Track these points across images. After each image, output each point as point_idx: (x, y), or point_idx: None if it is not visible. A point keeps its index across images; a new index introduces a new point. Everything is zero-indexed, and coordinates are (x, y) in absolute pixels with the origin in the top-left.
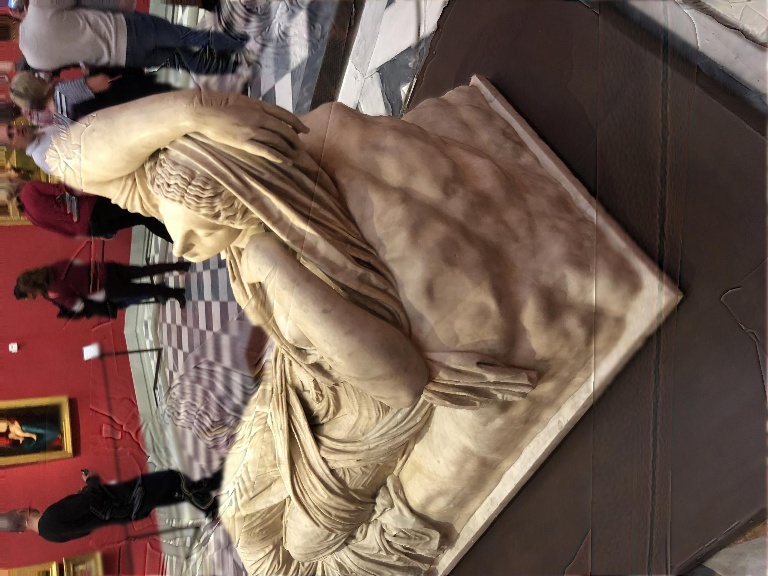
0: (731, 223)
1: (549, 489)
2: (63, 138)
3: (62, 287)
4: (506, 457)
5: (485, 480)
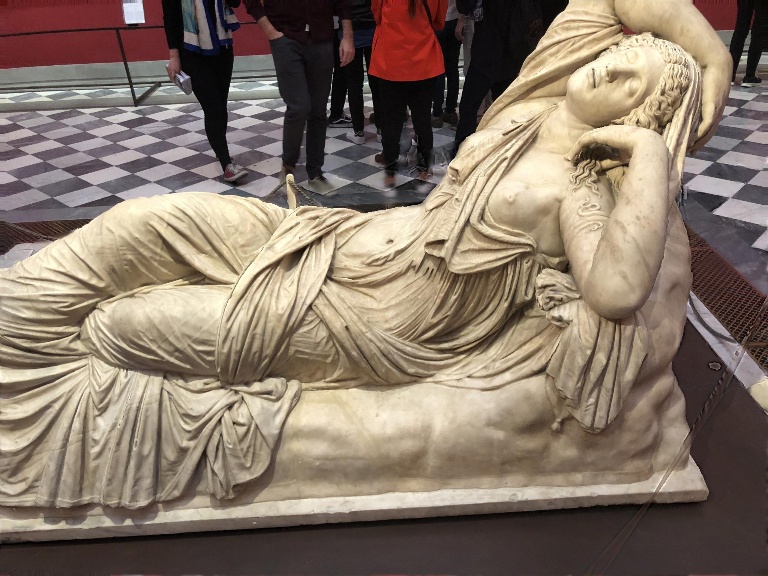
0: (765, 492)
1: (419, 543)
2: None
3: None
4: (428, 477)
5: (378, 476)
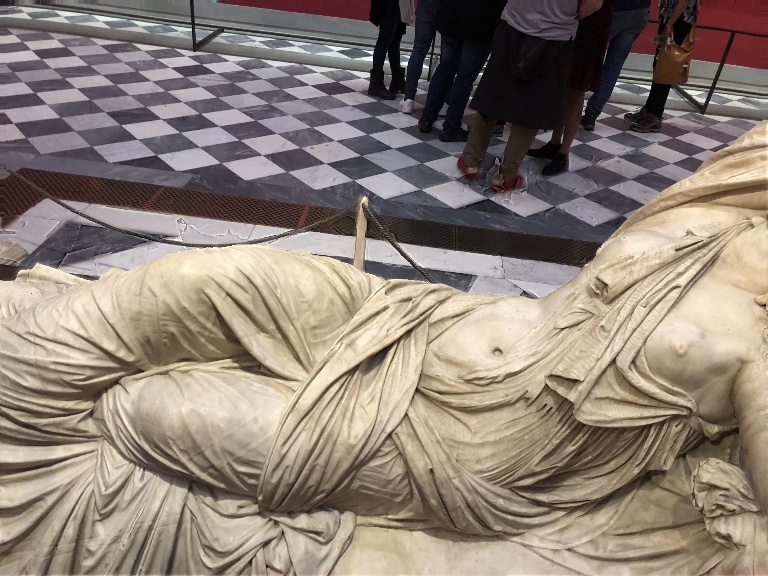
0: None
1: None
2: None
3: None
4: None
5: None
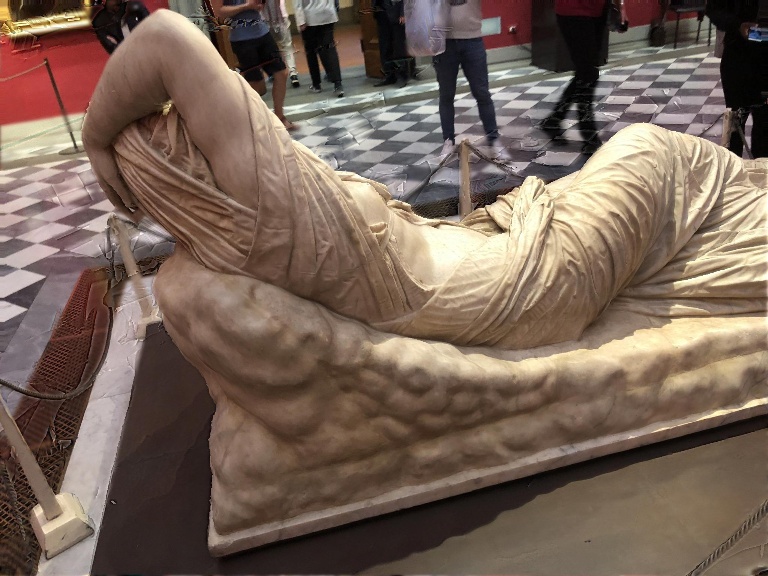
0: None
1: None
2: (39, 21)
3: (108, 6)
4: None
5: None
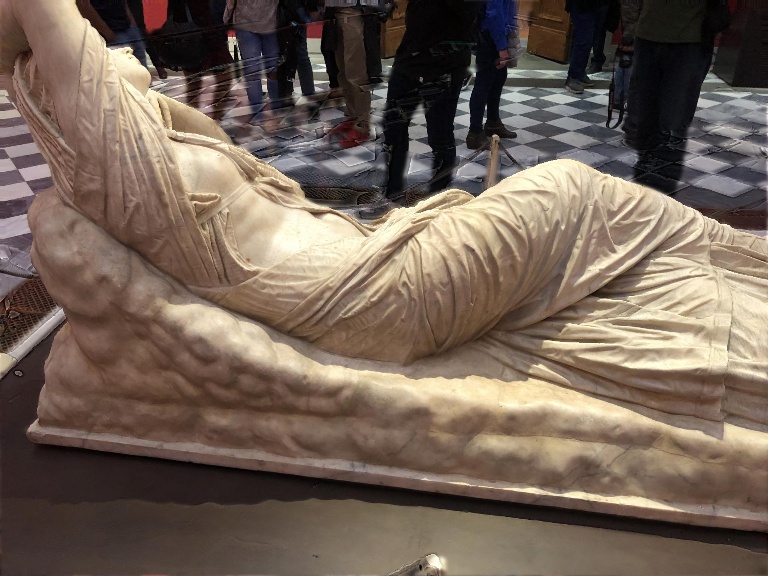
0: None
1: None
2: None
3: None
4: None
5: None
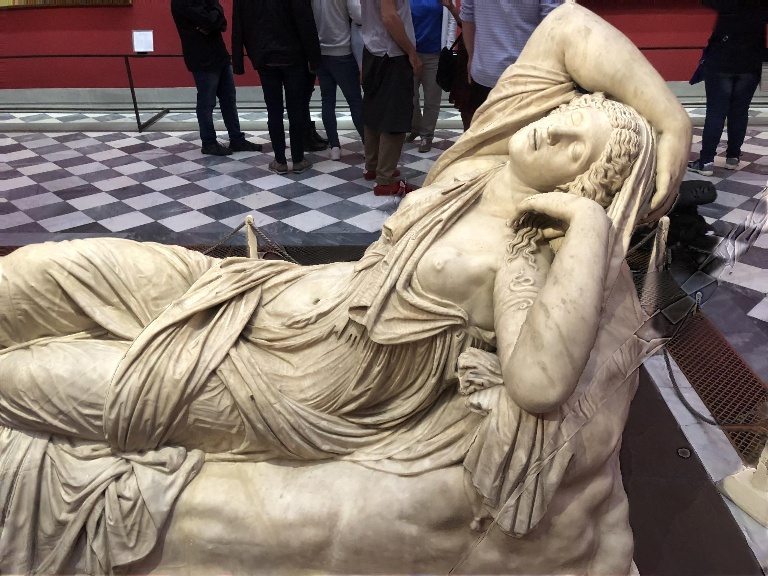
0: None
1: None
2: None
3: None
4: (333, 570)
5: (277, 566)
